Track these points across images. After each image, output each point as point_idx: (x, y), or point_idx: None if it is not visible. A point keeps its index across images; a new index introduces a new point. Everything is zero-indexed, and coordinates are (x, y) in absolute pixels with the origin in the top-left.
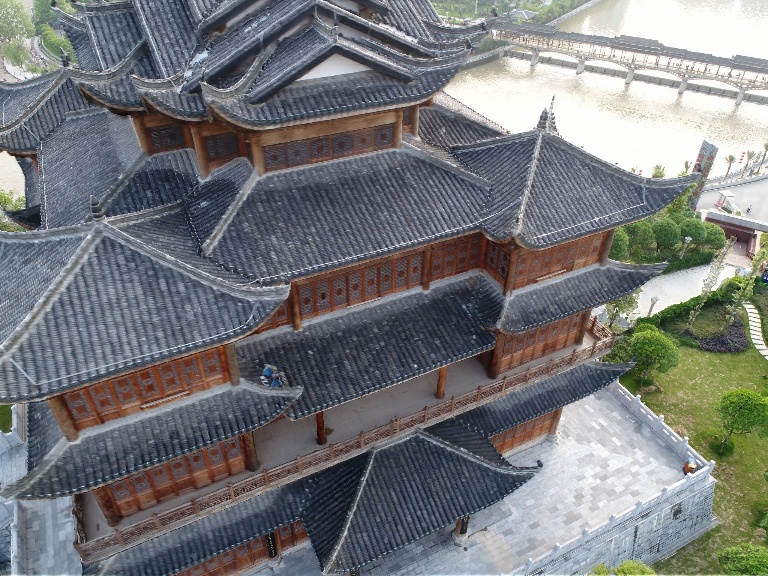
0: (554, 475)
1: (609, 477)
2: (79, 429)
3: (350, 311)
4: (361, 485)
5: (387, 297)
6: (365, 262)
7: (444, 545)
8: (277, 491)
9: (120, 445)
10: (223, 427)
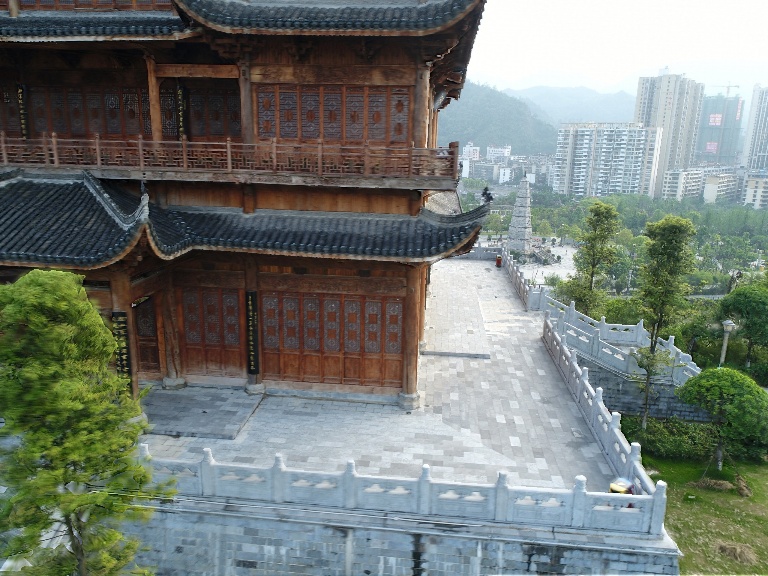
0: (356, 432)
1: (443, 465)
2: None
3: (77, 16)
4: None
5: (124, 11)
6: None
7: None
8: None
9: None
10: None
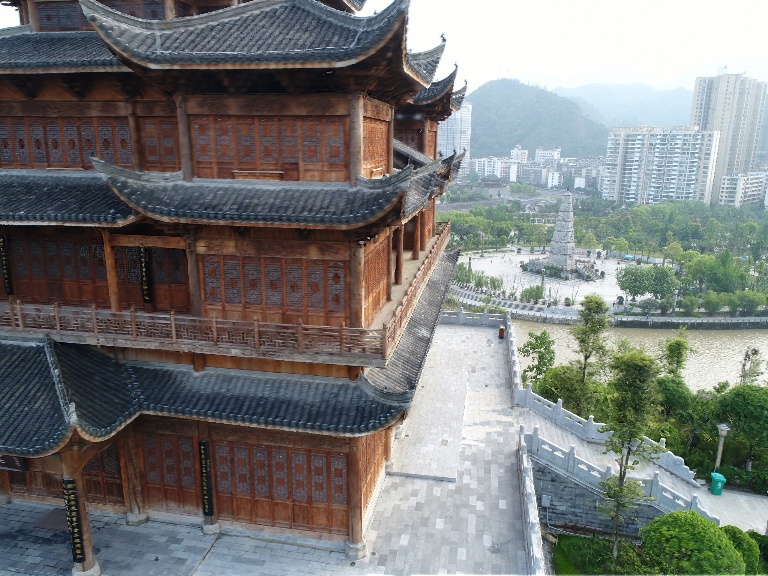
0: None
1: None
2: None
3: (49, 174)
4: None
5: (91, 171)
6: (7, 73)
7: (59, 572)
8: None
9: None
10: None
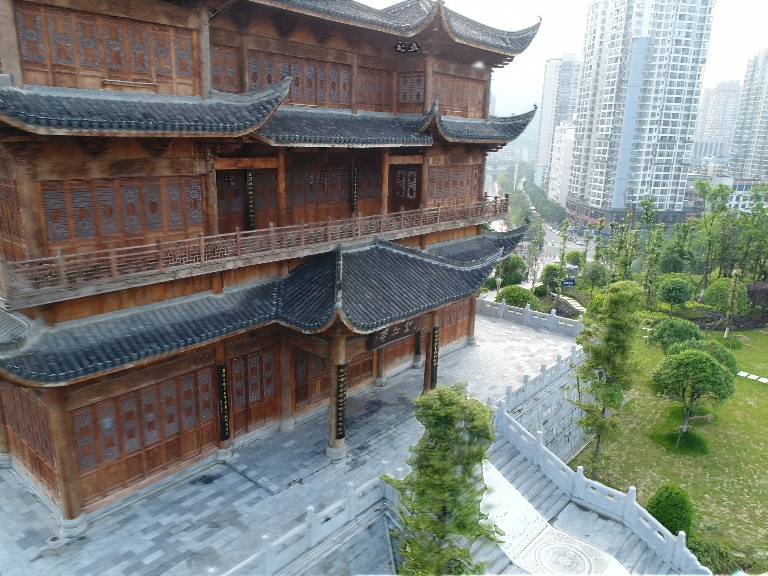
0: (489, 360)
1: (535, 354)
2: (24, 81)
3: (293, 109)
4: (340, 268)
5: (323, 108)
6: (318, 17)
7: None
8: (240, 297)
9: (81, 108)
10: (203, 122)
